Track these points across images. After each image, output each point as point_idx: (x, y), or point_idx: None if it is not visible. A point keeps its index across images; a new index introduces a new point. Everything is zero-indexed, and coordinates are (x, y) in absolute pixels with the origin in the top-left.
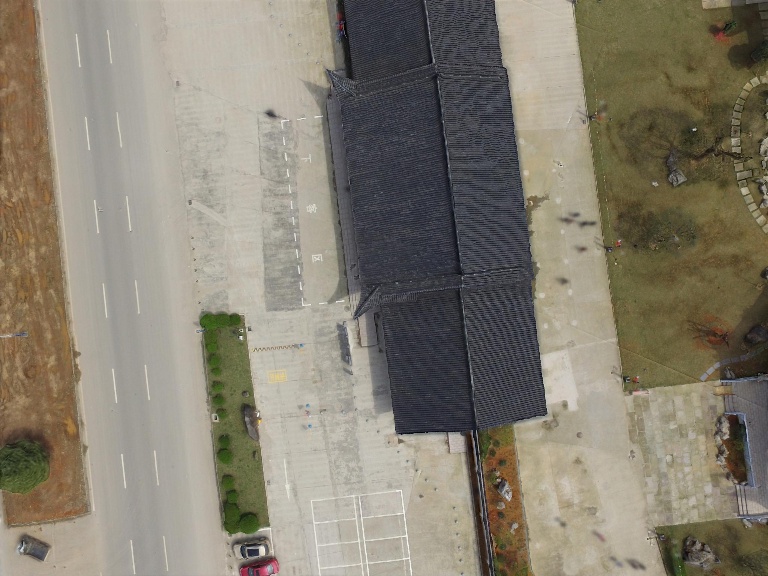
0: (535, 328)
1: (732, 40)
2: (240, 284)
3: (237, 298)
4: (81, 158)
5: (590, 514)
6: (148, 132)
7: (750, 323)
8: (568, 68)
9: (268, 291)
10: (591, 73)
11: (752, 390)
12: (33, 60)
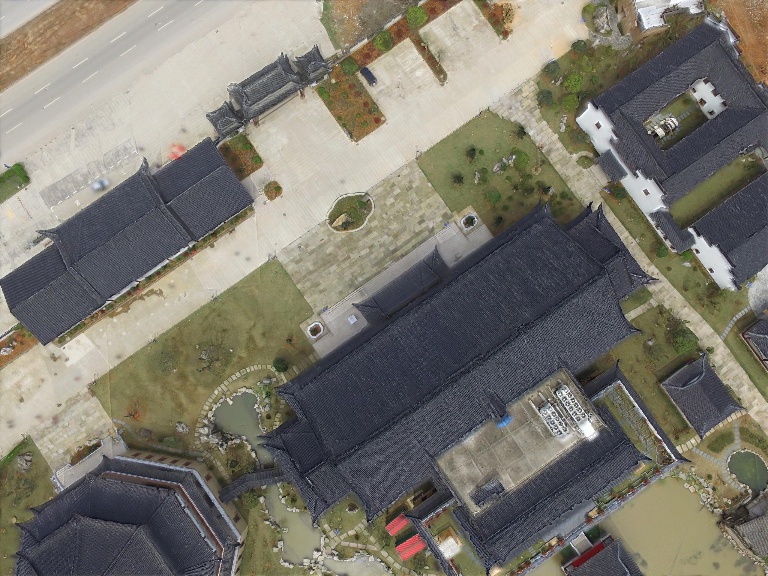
0: None
1: (290, 347)
2: (46, 173)
3: (38, 175)
4: (67, 66)
5: (20, 400)
6: (96, 91)
7: (151, 428)
8: (235, 275)
9: (49, 188)
10: (238, 287)
11: (119, 446)
12: (101, 19)
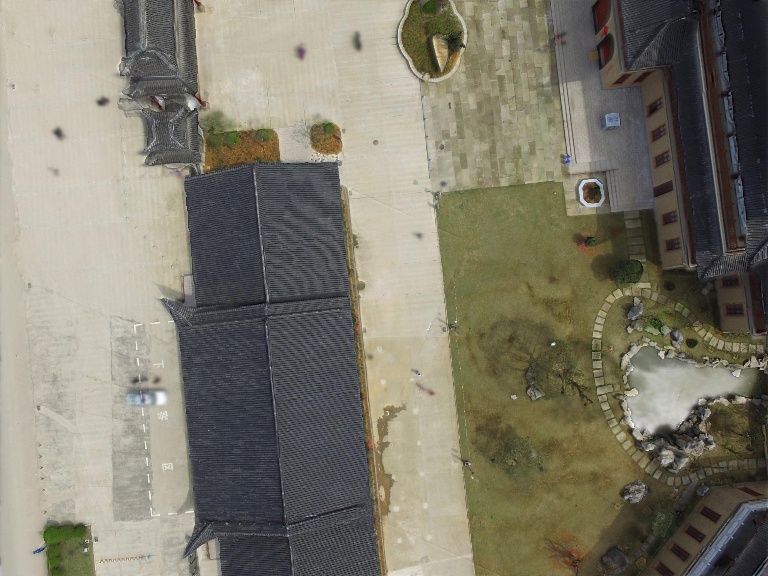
0: (376, 560)
1: (596, 249)
2: (88, 493)
3: (84, 507)
4: None
5: None
6: None
7: (607, 544)
8: (428, 274)
9: (116, 500)
10: (451, 280)
11: None
12: None
